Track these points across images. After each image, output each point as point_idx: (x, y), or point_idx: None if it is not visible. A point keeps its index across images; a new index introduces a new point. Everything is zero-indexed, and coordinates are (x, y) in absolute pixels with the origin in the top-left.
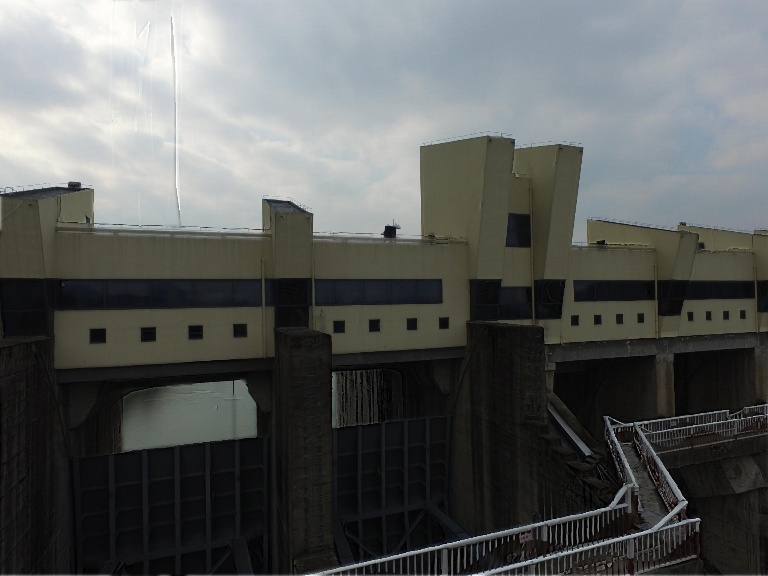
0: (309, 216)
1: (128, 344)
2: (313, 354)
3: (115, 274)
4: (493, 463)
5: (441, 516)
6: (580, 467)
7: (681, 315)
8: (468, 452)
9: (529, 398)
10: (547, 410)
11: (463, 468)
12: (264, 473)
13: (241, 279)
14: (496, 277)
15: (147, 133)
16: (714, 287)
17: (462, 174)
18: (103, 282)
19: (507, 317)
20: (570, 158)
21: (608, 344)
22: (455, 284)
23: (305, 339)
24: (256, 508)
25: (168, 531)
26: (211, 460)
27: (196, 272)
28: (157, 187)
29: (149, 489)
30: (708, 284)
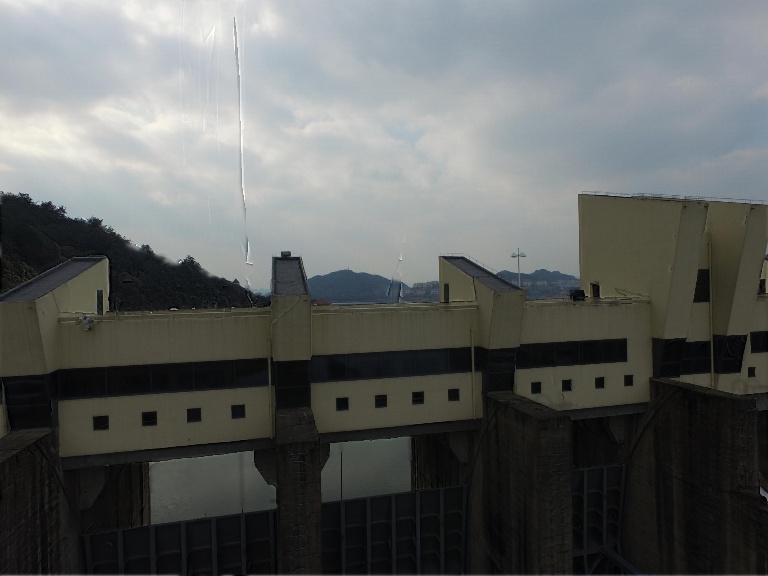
0: (522, 293)
1: (365, 410)
2: (557, 435)
3: (354, 349)
4: (689, 521)
5: (624, 563)
6: None
7: None
8: (651, 504)
9: (742, 468)
10: (758, 479)
11: (643, 517)
12: (463, 518)
13: (453, 348)
14: (681, 336)
15: (214, 134)
16: None
17: (642, 233)
18: (345, 356)
19: (686, 372)
20: (760, 216)
21: None
22: (639, 342)
23: (550, 421)
24: (452, 548)
25: (383, 567)
26: (420, 507)
27: (417, 344)
28: (224, 186)
29: (371, 532)
30: None
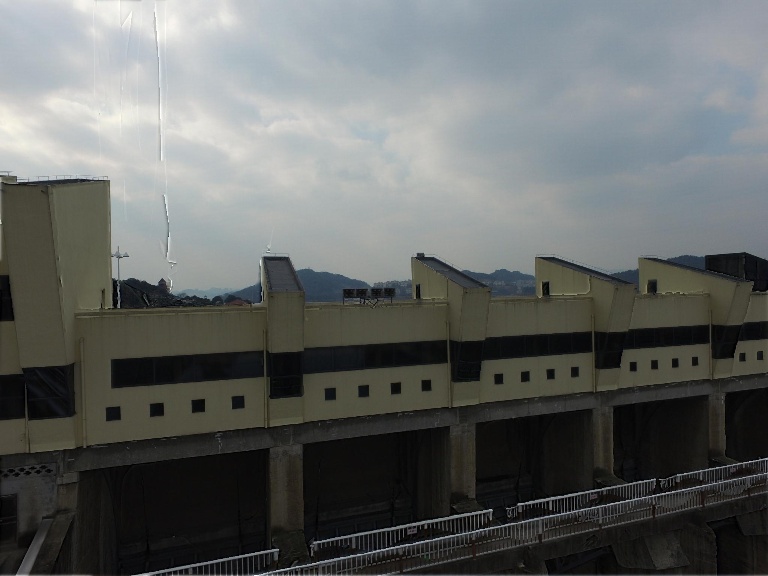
0: None
1: None
2: None
3: None
4: None
5: None
6: None
7: (312, 394)
8: None
9: None
10: None
11: None
12: None
13: None
14: None
15: (133, 126)
16: (379, 352)
17: None
18: None
19: None
20: (27, 202)
21: (181, 440)
22: None
23: None
24: None
25: None
26: None
27: None
28: (145, 180)
29: None
30: (365, 349)
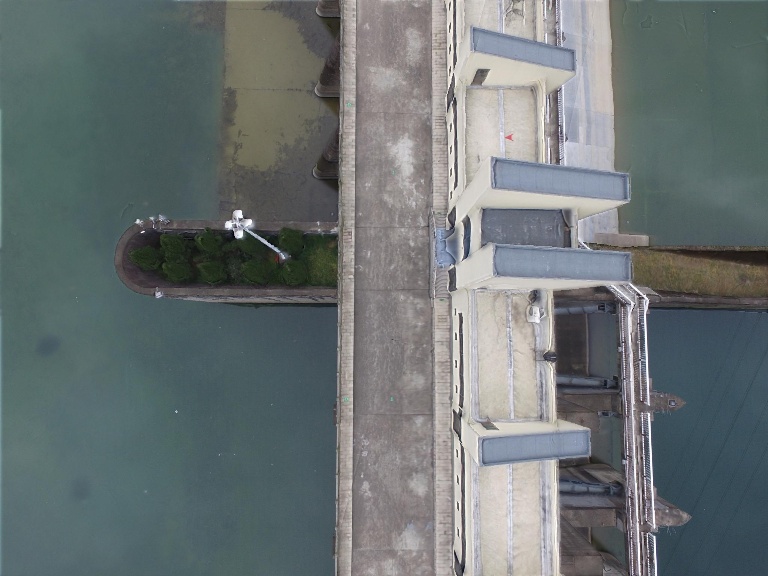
0: None
1: None
2: None
3: None
4: None
5: None
6: (600, 299)
7: None
8: None
9: None
10: None
11: None
12: None
13: None
14: None
15: None
16: None
17: None
18: None
19: None
20: None
21: None
22: None
23: None
24: None
25: None
26: None
27: None
28: None
29: None
30: None
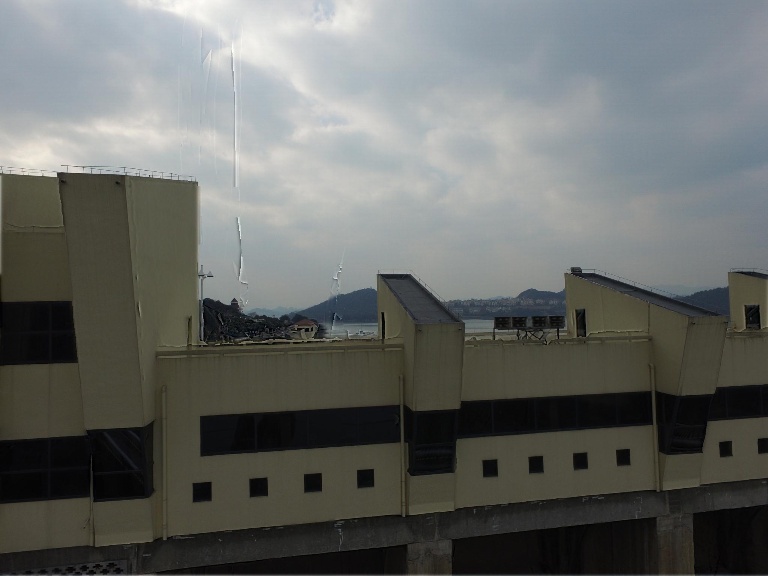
0: None
1: None
2: None
3: None
4: None
5: None
6: None
7: (465, 468)
8: None
9: None
10: None
11: None
12: None
13: None
14: None
15: (211, 155)
16: (555, 407)
17: None
18: None
19: (35, 495)
20: (98, 198)
21: (289, 530)
22: None
23: None
24: None
25: None
26: None
27: None
28: (220, 205)
29: None
30: (536, 404)
